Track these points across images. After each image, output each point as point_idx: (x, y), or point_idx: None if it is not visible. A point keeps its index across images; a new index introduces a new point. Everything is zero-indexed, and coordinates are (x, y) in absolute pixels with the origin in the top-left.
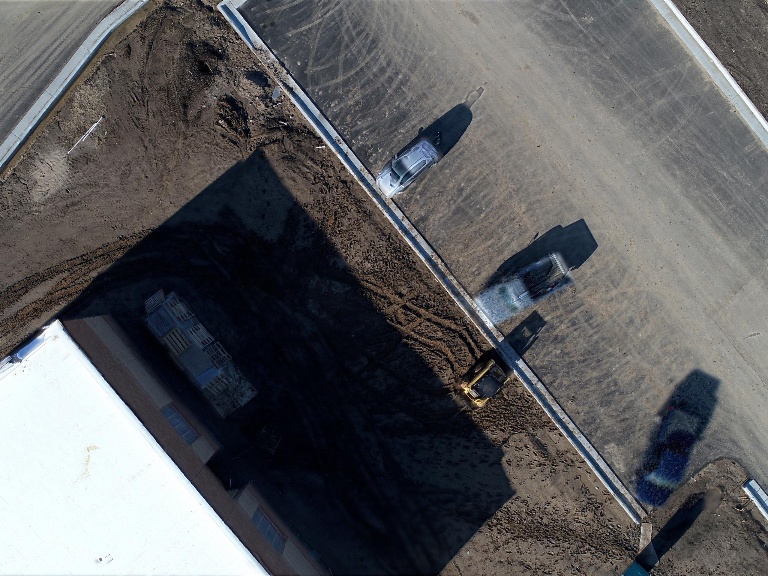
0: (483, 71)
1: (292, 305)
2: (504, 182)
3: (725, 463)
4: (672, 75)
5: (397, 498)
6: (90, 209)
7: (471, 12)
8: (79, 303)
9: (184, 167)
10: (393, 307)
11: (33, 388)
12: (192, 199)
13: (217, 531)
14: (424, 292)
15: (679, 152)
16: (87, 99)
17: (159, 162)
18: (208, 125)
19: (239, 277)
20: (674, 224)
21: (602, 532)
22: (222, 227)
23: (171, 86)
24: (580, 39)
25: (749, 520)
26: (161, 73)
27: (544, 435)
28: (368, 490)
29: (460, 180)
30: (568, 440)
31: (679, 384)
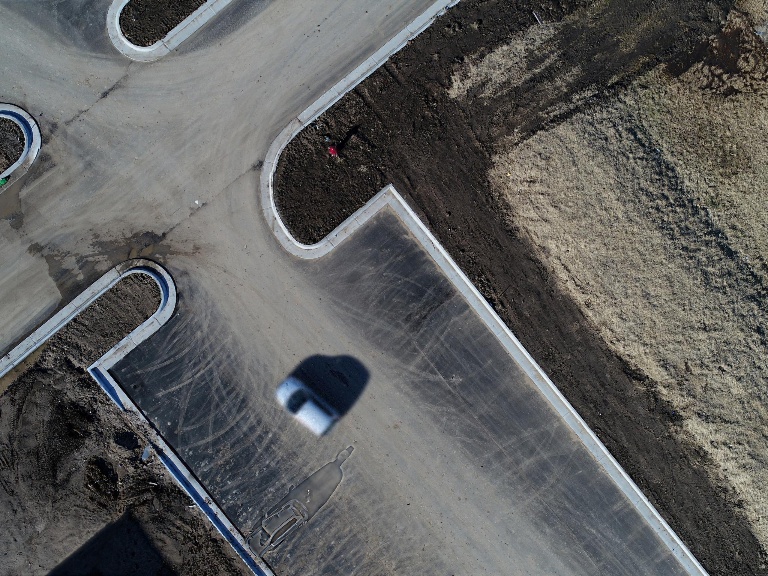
0: (353, 430)
1: None
2: (374, 539)
3: None
4: (540, 435)
5: None
6: None
7: (340, 372)
8: None
9: (53, 530)
10: None
11: None
12: (61, 562)
13: None
14: None
15: (548, 510)
16: None
17: (28, 525)
18: (78, 488)
19: None
20: None
21: None
22: None
23: (41, 449)
24: (449, 399)
25: None
26: (31, 436)
27: None
28: None
29: (330, 538)
30: None
31: None
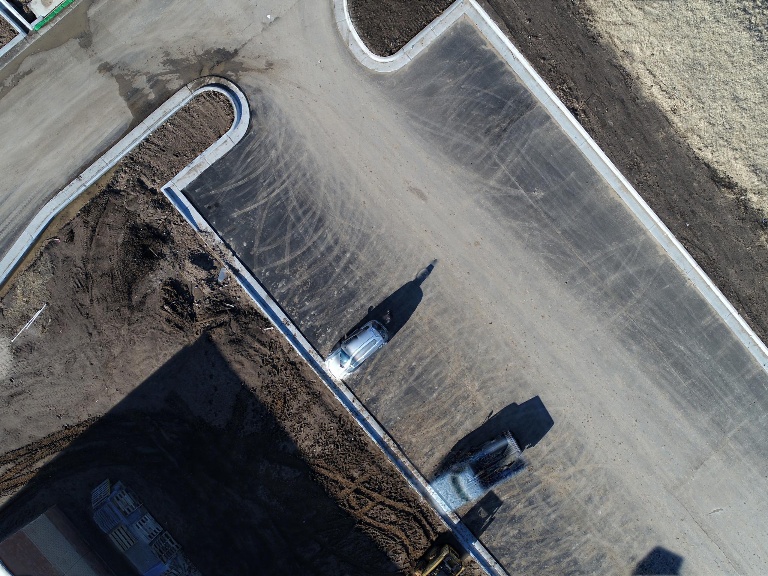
0: (432, 248)
1: (242, 492)
2: (456, 360)
3: None
4: (626, 249)
5: None
6: (35, 398)
7: (419, 189)
8: (25, 494)
9: (130, 353)
10: (345, 491)
11: None
12: (138, 385)
13: None
14: (377, 474)
15: (635, 327)
16: (30, 286)
17: (104, 348)
18: (153, 310)
19: (187, 464)
20: (632, 399)
21: None
22: (169, 413)
23: (115, 271)
24: (531, 214)
25: None
26: (105, 258)
27: None
28: None
29: (411, 359)
30: None
31: (641, 562)
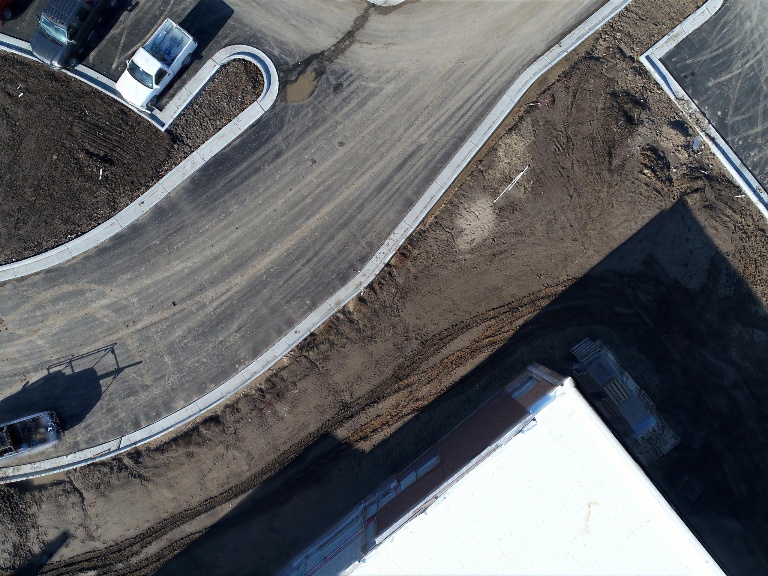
0: None
1: (716, 354)
2: None
3: None
4: None
5: None
6: (516, 258)
7: None
8: (504, 351)
9: (608, 216)
10: None
11: (538, 444)
12: (616, 248)
13: None
14: None
15: None
16: (512, 148)
17: (583, 211)
18: (632, 174)
19: (662, 326)
20: None
21: None
22: (646, 276)
23: (595, 136)
24: None
25: None
26: (585, 123)
27: None
28: None
29: None
30: None
31: None
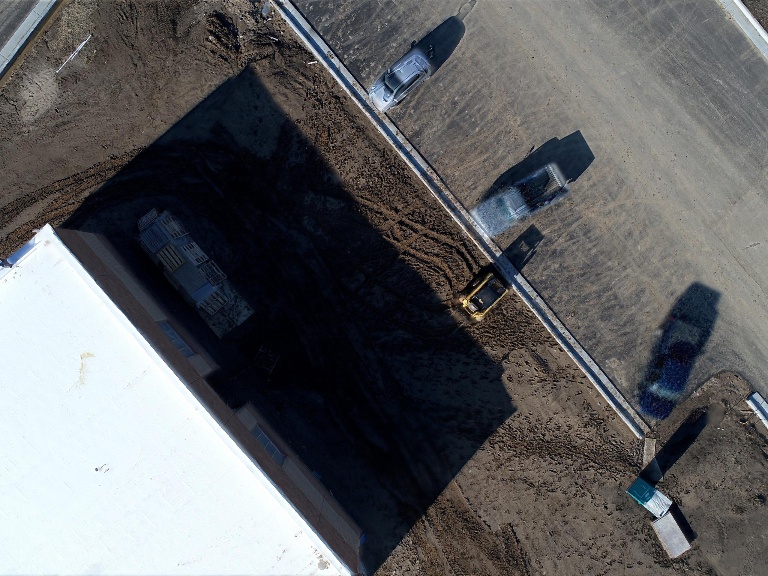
0: None
1: (287, 222)
2: (499, 95)
3: (728, 376)
4: None
5: (397, 417)
6: (80, 129)
7: None
8: (71, 224)
9: (175, 85)
10: (389, 223)
11: (24, 295)
12: (183, 117)
13: (214, 439)
14: (420, 207)
15: (675, 61)
16: (75, 17)
17: (149, 80)
18: (198, 42)
19: (232, 195)
20: (671, 134)
21: (605, 448)
22: (214, 145)
23: (160, 3)
24: None
25: (753, 433)
26: None
27: (544, 351)
28: (367, 409)
29: (454, 93)
30: (569, 355)
31: (680, 297)
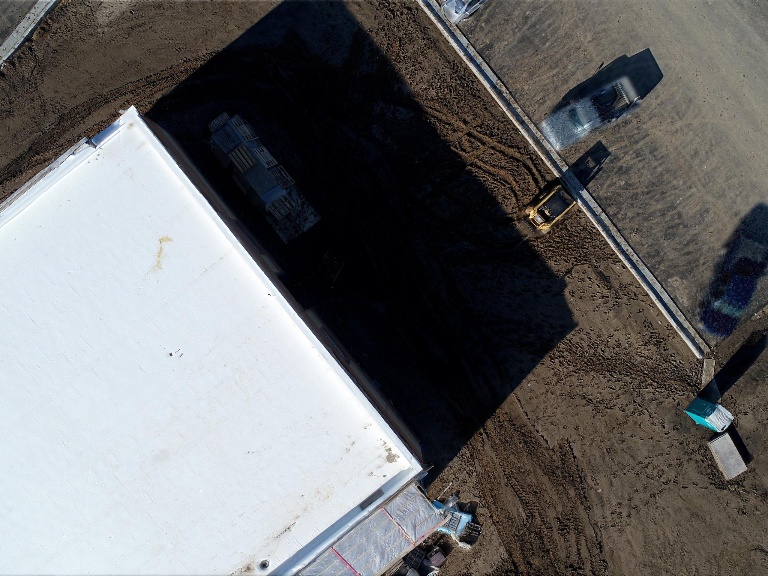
0: None
1: (356, 130)
2: (570, 11)
3: None
4: None
5: (459, 328)
6: (154, 31)
7: None
8: None
9: None
10: (457, 134)
11: (106, 177)
12: (256, 22)
13: (288, 328)
14: (488, 120)
15: None
16: None
17: None
18: None
19: (303, 102)
20: (740, 55)
21: (664, 367)
22: (286, 51)
23: None
24: None
25: None
26: None
27: (607, 267)
28: (430, 319)
29: (525, 8)
30: (631, 272)
31: (744, 218)
